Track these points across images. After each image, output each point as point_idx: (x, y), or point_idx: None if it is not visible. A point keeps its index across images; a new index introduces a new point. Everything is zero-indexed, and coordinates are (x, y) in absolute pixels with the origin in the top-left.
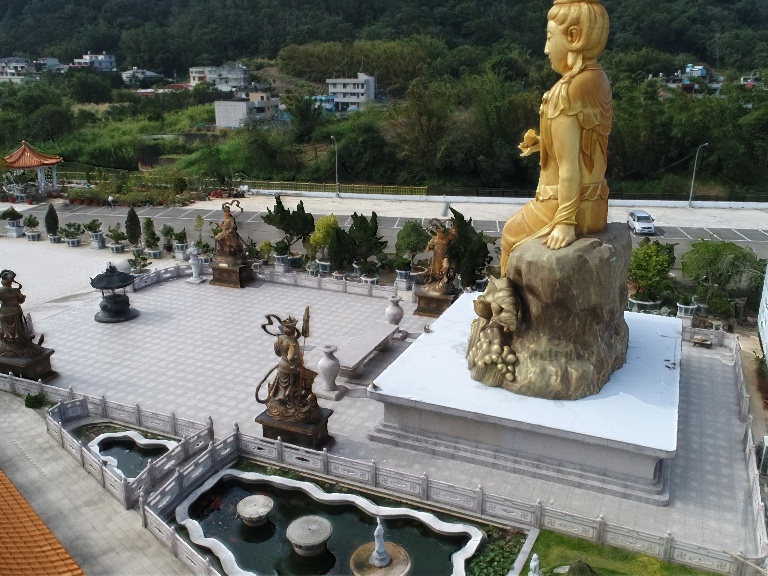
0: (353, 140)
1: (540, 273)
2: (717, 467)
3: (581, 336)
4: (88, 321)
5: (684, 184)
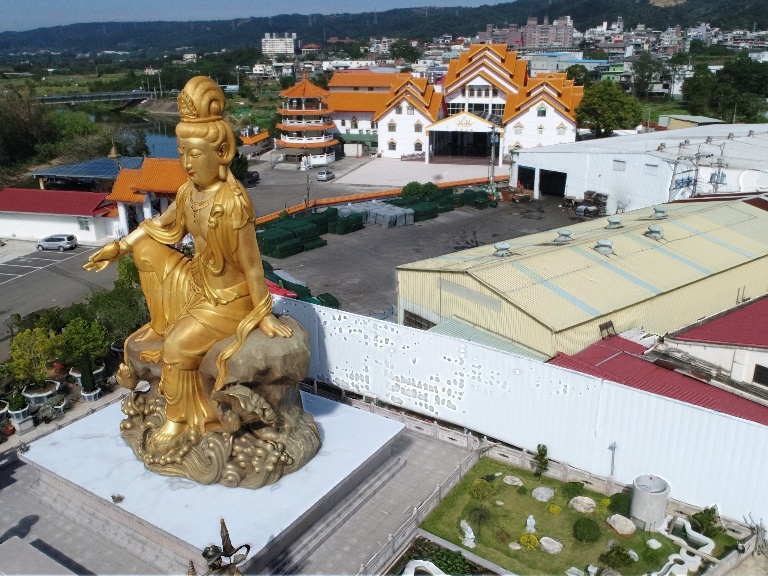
0: None
1: (296, 360)
2: None
3: (295, 397)
4: None
5: None
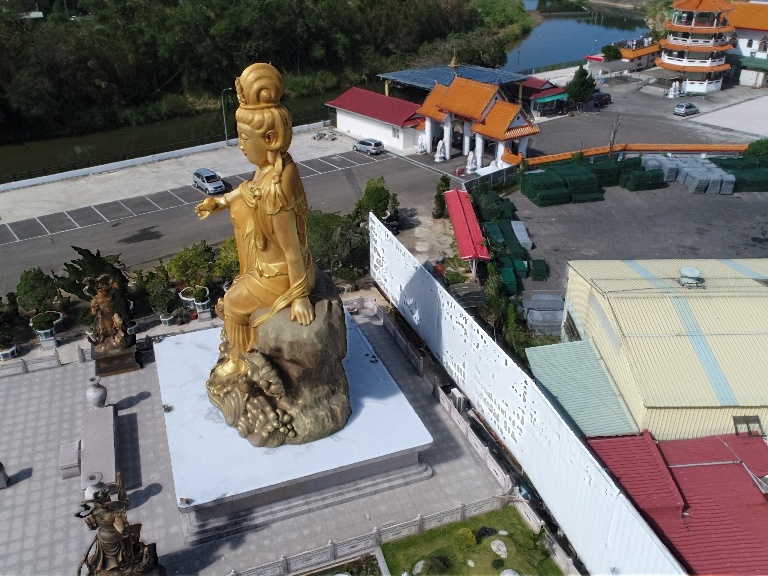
0: None
1: (303, 349)
2: (435, 425)
3: (330, 376)
4: None
5: (218, 126)
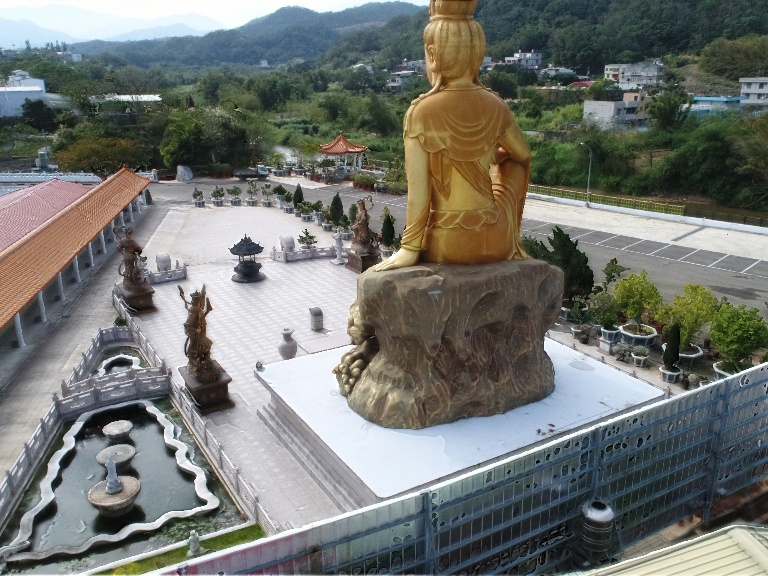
0: (692, 148)
1: (358, 292)
2: None
3: (413, 366)
4: (227, 278)
5: None
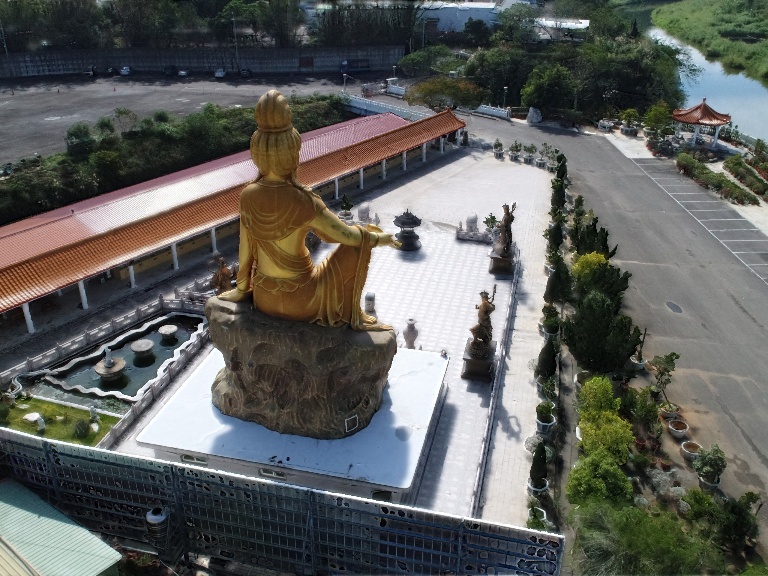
0: None
1: None
2: None
3: None
4: None
5: None
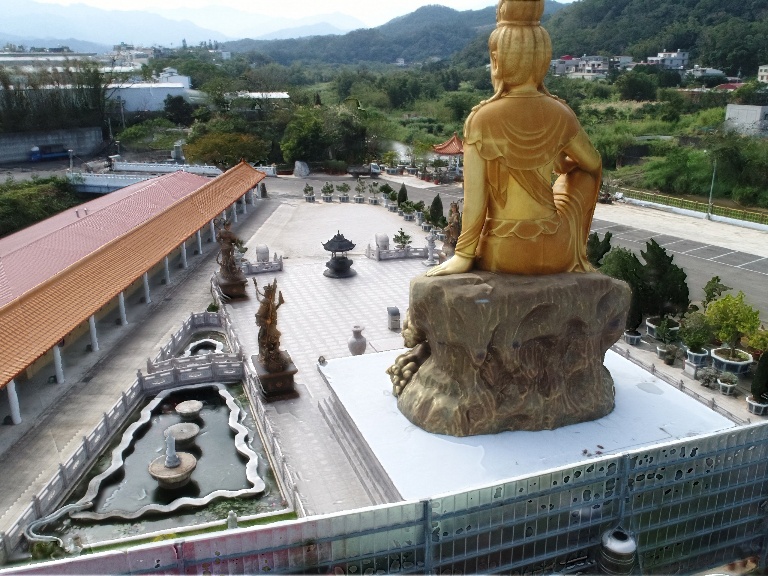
0: None
1: None
2: None
3: (460, 374)
4: (320, 272)
5: None
